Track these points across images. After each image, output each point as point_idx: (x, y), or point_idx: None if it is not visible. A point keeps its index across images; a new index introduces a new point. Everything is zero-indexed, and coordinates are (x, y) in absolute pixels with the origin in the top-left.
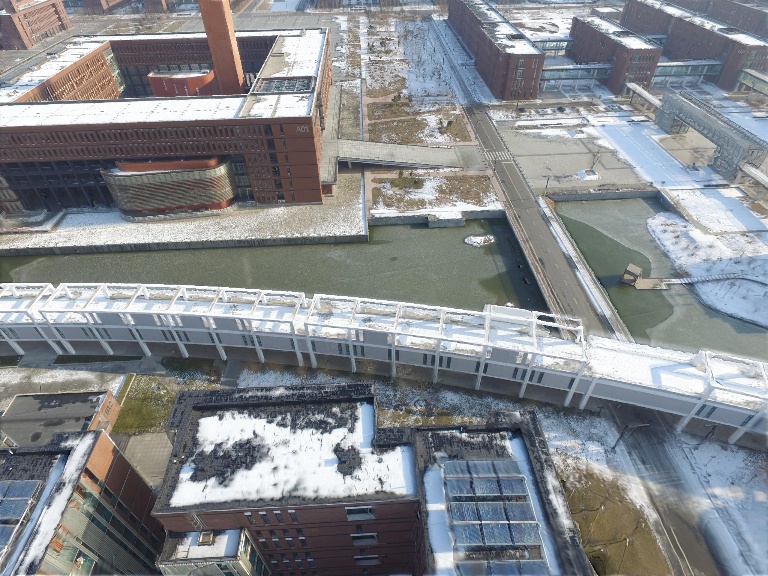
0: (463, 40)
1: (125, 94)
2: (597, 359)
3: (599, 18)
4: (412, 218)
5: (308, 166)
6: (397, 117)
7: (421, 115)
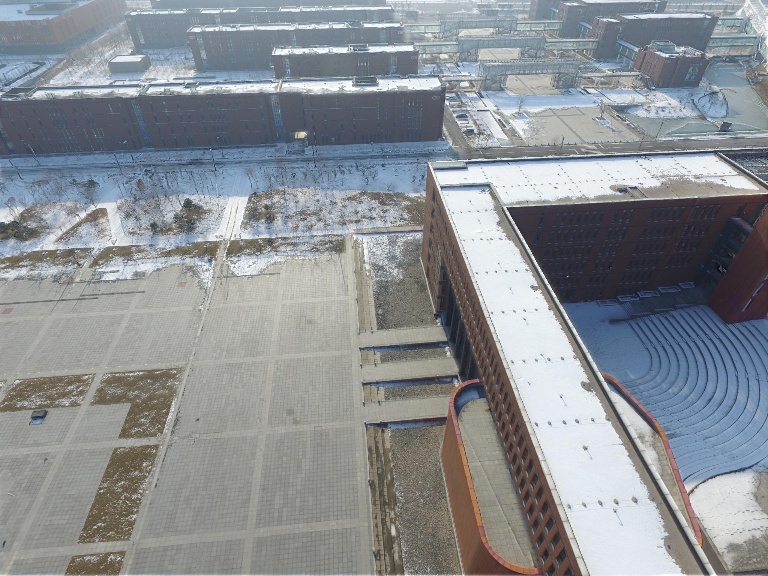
0: (176, 145)
1: None
2: None
3: (282, 49)
4: None
5: None
6: None
7: None
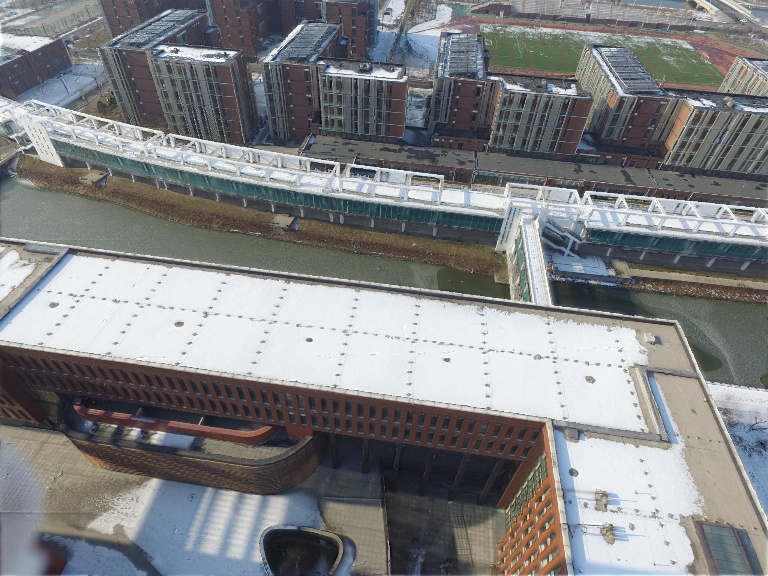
0: None
1: None
2: None
3: None
4: None
5: None
6: None
7: None
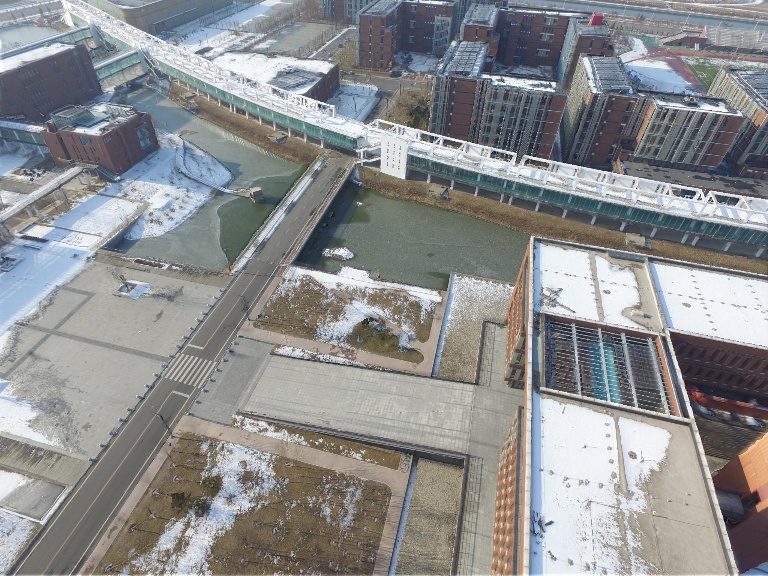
0: None
1: None
2: (363, 131)
3: None
4: None
5: None
6: None
7: None
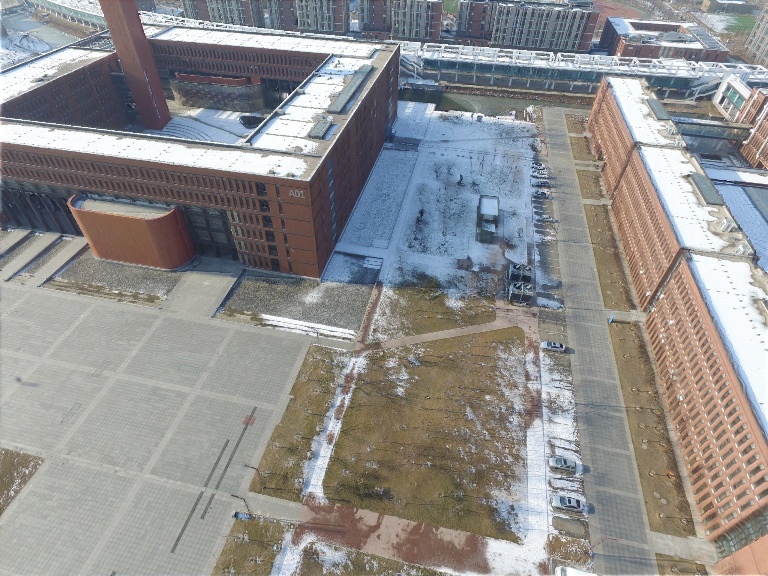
0: None
1: None
2: None
3: None
4: None
5: None
6: None
7: None
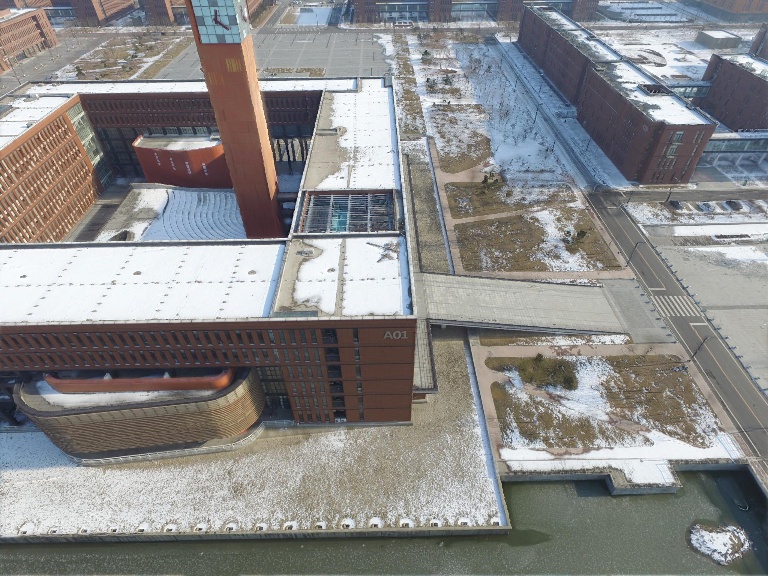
0: (548, 75)
1: (102, 165)
2: None
3: (749, 57)
4: (580, 474)
5: (396, 381)
6: (493, 213)
7: (528, 210)
